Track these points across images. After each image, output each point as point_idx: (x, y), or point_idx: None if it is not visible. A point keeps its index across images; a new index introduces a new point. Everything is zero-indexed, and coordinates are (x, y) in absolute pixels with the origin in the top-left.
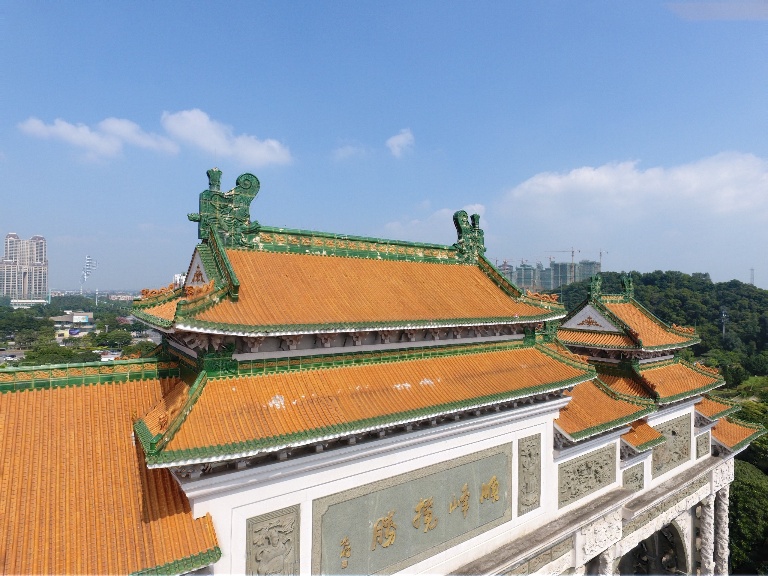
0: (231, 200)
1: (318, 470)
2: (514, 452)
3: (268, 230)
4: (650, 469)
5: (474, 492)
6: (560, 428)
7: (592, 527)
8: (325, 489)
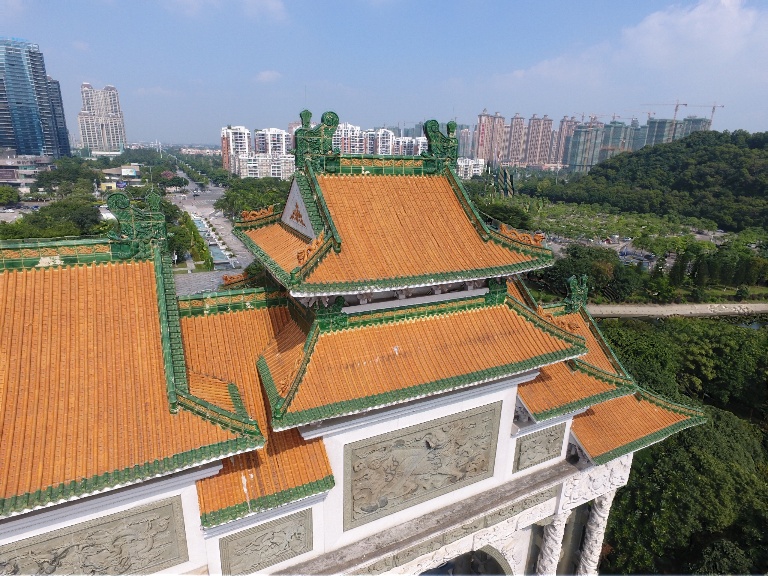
0: None
1: None
2: None
3: None
4: (337, 516)
5: None
6: None
7: None
8: None
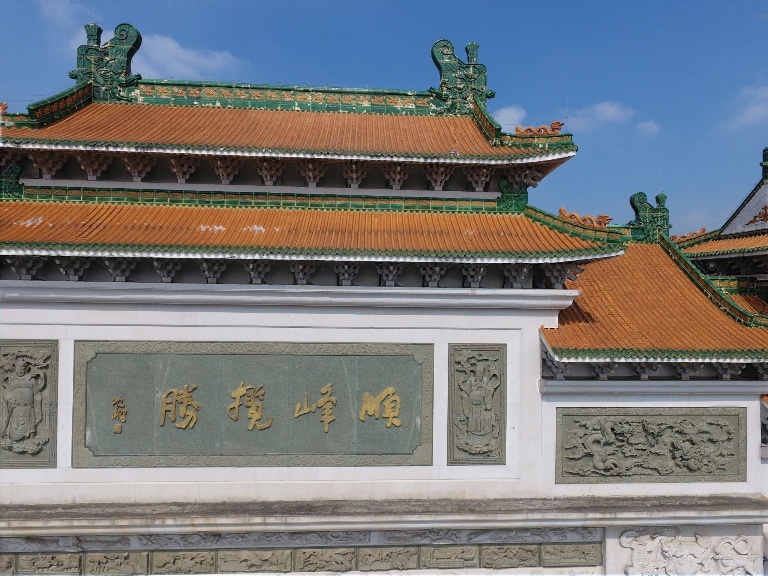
0: (106, 53)
1: (80, 307)
2: (439, 361)
3: (149, 82)
4: None
5: (347, 401)
6: (544, 339)
7: (653, 542)
8: (92, 332)
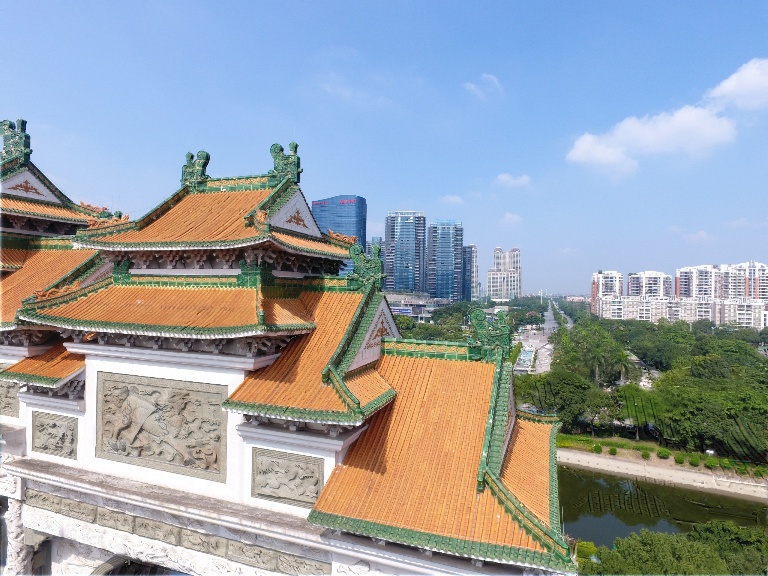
0: None
1: None
2: None
3: None
4: (92, 437)
5: None
6: None
7: None
8: None
